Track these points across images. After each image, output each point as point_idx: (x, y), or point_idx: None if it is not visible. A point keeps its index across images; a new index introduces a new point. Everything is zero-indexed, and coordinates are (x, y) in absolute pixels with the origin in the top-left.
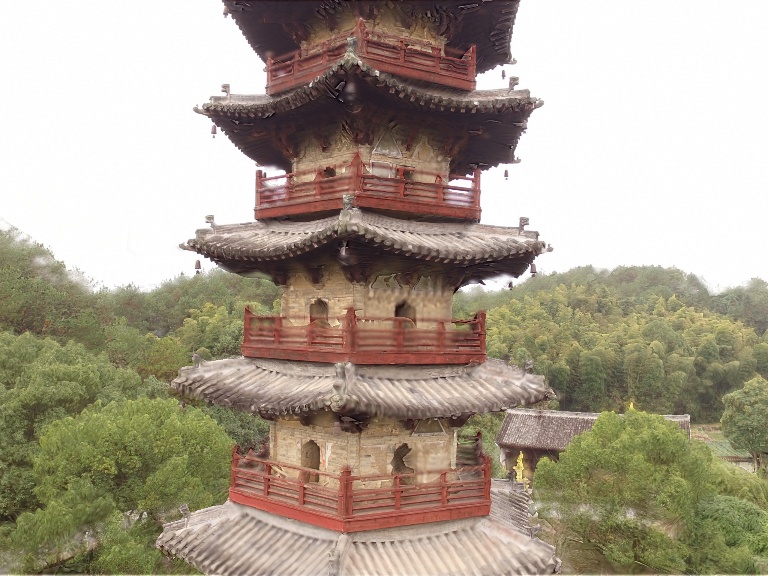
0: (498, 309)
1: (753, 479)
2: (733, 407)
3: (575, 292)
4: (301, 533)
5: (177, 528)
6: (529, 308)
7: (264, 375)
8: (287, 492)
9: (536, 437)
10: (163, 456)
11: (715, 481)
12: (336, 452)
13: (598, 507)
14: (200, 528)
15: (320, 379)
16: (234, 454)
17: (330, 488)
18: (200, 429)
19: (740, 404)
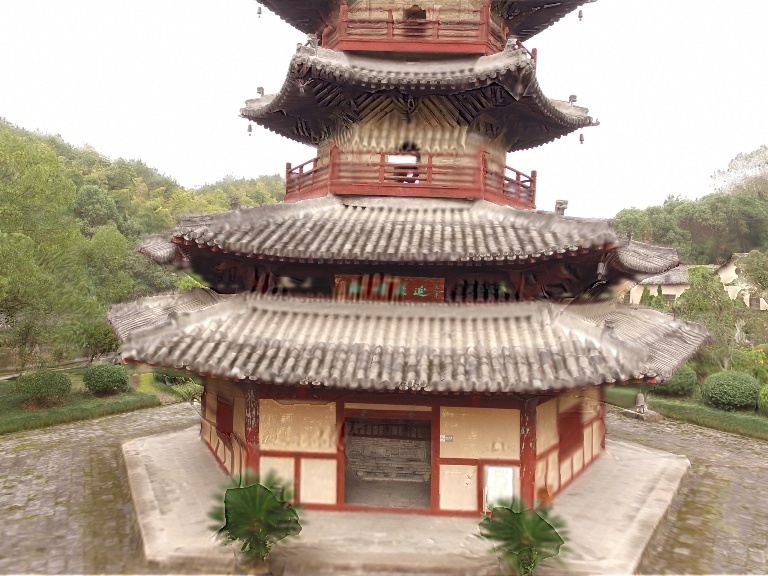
0: (203, 196)
1: None
2: None
3: (277, 187)
4: (425, 71)
5: (310, 53)
6: (235, 197)
7: None
8: (416, 32)
9: None
10: (7, 170)
11: None
12: (445, 12)
13: None
14: (326, 62)
15: None
16: (343, 6)
17: (470, 19)
18: (41, 154)
19: None
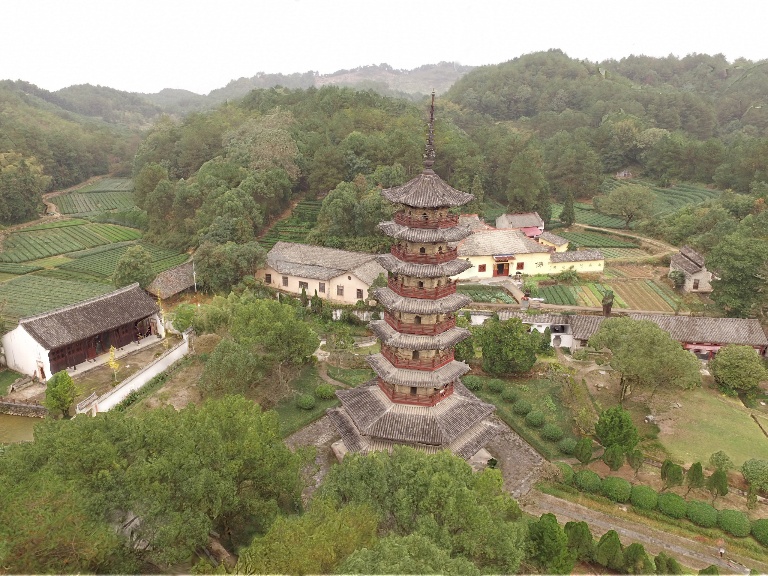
0: None
1: (228, 310)
2: (131, 267)
3: None
4: None
5: None
6: None
7: (439, 338)
8: None
9: (69, 333)
10: None
11: (218, 317)
12: None
13: (285, 347)
14: None
15: (448, 332)
16: None
17: None
18: None
19: (136, 265)
